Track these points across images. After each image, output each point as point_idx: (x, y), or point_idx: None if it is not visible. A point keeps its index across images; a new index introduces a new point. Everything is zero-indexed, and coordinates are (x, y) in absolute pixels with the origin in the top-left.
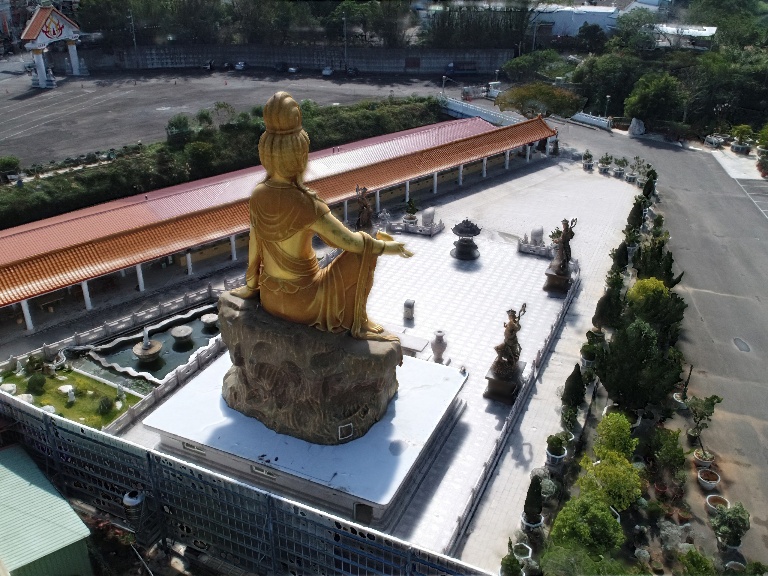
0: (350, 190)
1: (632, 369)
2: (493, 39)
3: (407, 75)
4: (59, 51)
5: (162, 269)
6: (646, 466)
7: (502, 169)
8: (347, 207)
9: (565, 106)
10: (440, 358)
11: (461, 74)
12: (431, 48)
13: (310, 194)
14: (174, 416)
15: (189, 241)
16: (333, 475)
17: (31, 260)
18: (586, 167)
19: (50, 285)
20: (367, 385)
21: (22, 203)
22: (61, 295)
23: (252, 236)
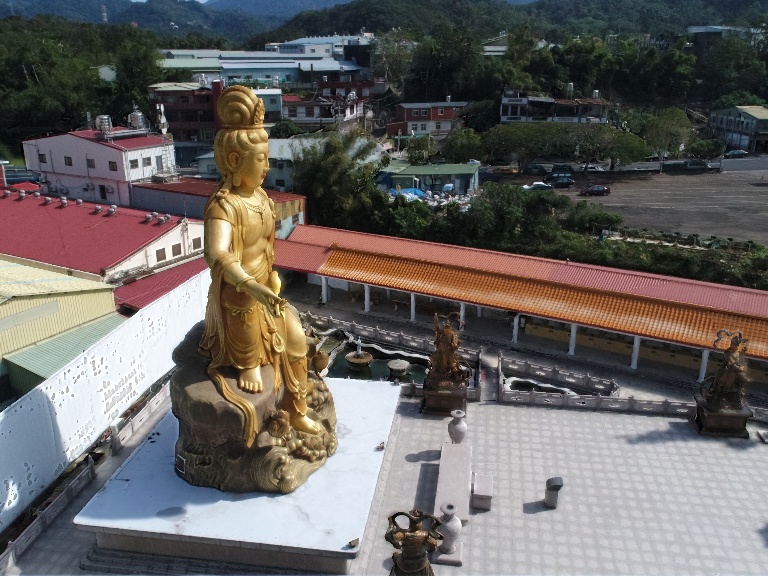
0: None
1: None
2: None
3: None
4: None
5: (509, 327)
6: None
7: None
8: None
9: None
10: (445, 546)
11: None
12: None
13: None
14: None
15: (515, 304)
16: (126, 479)
17: (393, 258)
18: None
19: (382, 281)
20: None
21: (586, 254)
22: None
23: None
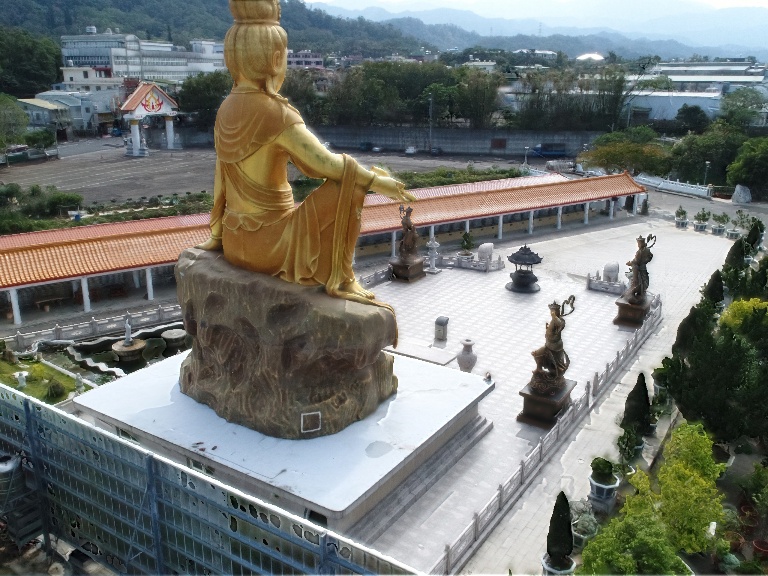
0: (399, 220)
1: (718, 382)
2: (584, 122)
3: (492, 156)
4: (158, 128)
5: None
6: (740, 517)
7: (580, 223)
8: (397, 243)
9: (656, 163)
10: None
11: (549, 155)
12: (518, 129)
13: (279, 99)
14: (112, 396)
15: None
16: (280, 471)
17: (30, 249)
18: (679, 225)
19: (43, 275)
20: (341, 358)
21: None
22: (64, 298)
23: (217, 167)
